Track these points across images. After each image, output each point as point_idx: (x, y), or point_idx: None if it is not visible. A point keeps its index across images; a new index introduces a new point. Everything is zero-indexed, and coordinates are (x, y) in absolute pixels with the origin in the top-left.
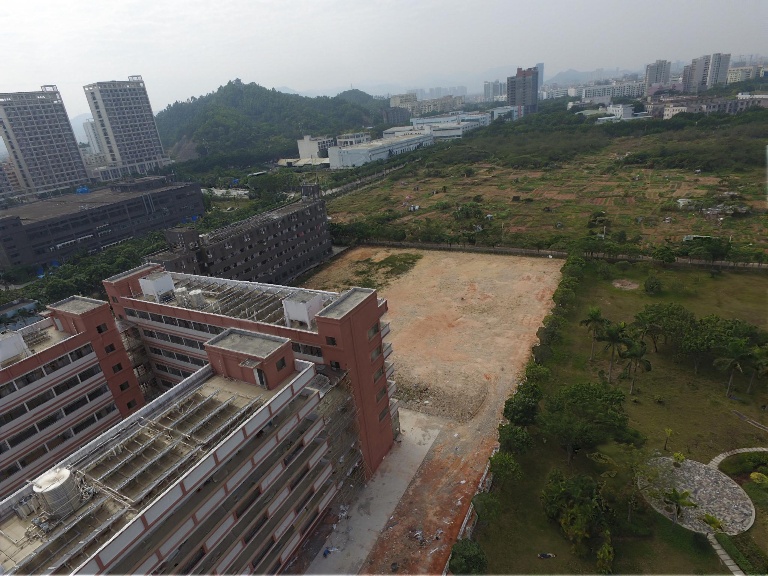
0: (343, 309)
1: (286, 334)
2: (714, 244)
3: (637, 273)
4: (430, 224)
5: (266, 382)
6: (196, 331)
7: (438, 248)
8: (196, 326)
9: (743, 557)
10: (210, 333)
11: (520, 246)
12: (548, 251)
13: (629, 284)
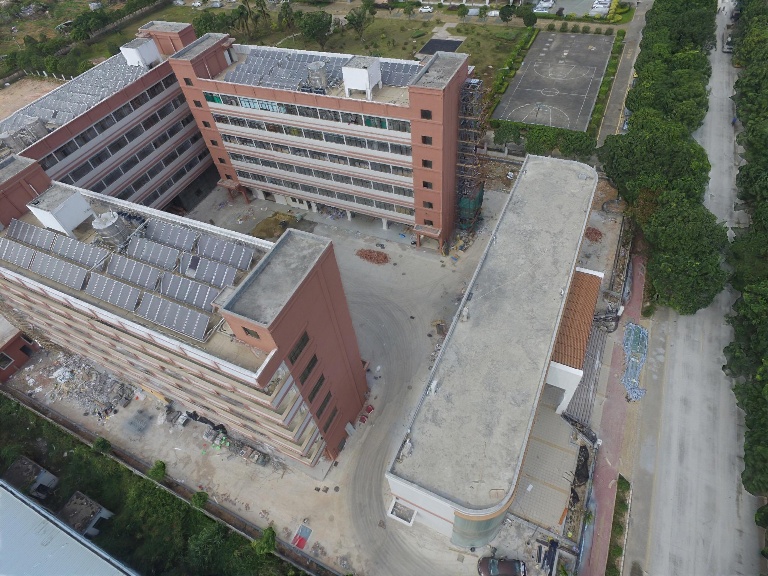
0: (171, 30)
1: (165, 69)
2: (96, 13)
3: (85, 55)
4: None
5: (235, 55)
6: (82, 147)
7: None
8: (79, 142)
9: None
10: (99, 134)
11: None
12: None
13: (98, 60)
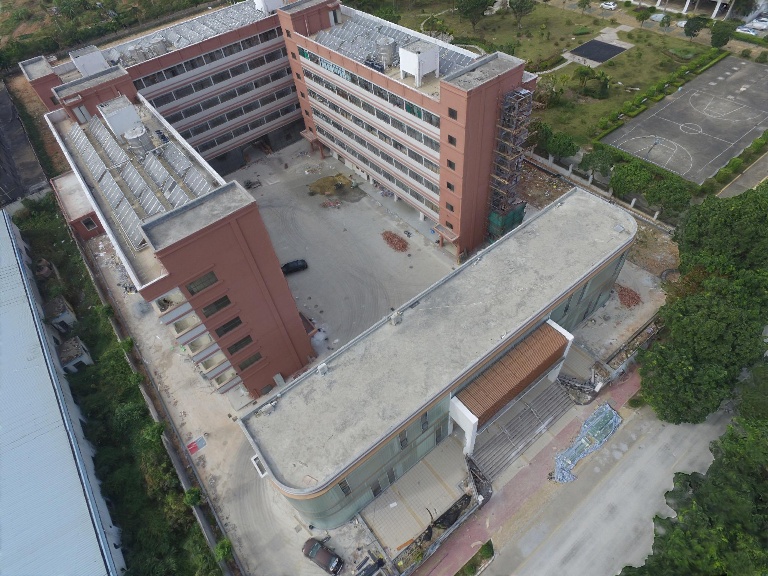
0: None
1: None
2: None
3: None
4: (61, 25)
5: (340, 17)
6: (189, 72)
7: (106, 41)
8: (187, 66)
9: (462, 41)
10: (206, 64)
11: (182, 7)
12: (205, 3)
13: None
